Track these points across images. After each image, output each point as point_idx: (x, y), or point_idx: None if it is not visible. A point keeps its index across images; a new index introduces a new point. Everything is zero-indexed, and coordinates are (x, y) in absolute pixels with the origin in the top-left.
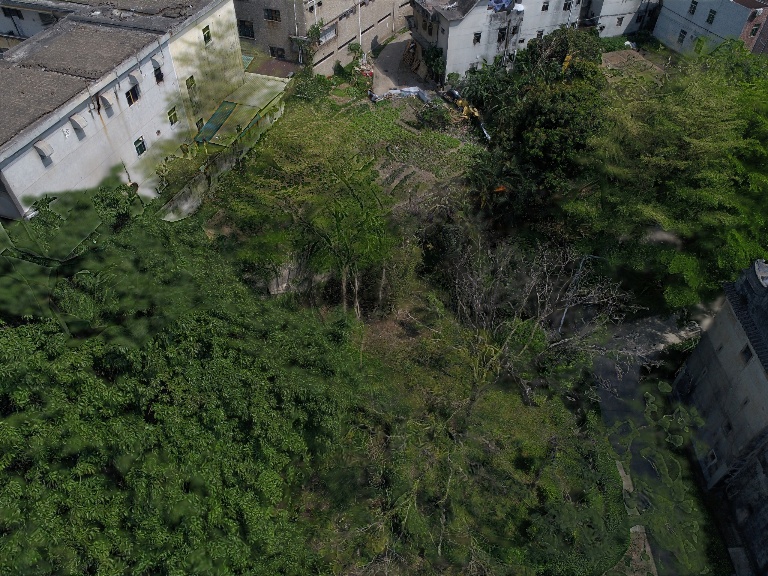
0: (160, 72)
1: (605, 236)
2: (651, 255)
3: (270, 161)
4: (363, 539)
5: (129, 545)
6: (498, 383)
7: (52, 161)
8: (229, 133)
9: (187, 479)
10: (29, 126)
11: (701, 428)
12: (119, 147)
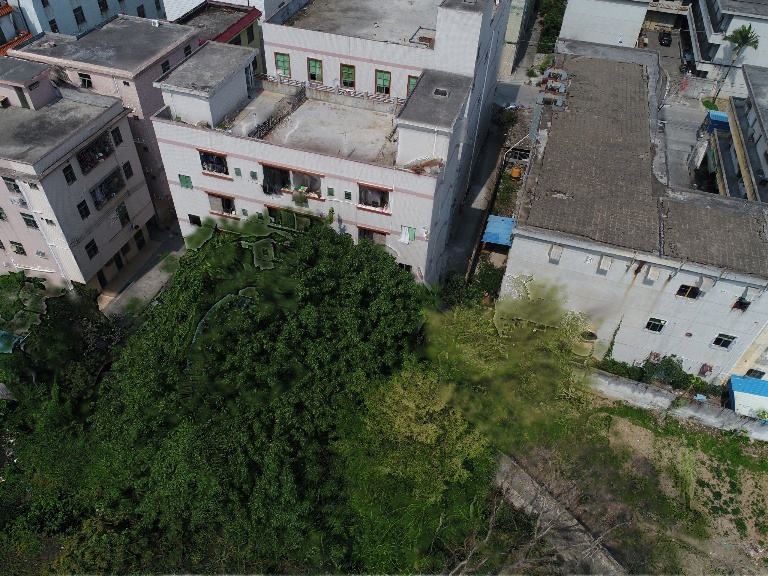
0: (749, 303)
1: None
2: None
3: (550, 421)
4: (167, 575)
5: None
6: None
7: (559, 264)
8: (761, 408)
9: (168, 411)
10: (568, 233)
11: None
12: (631, 307)
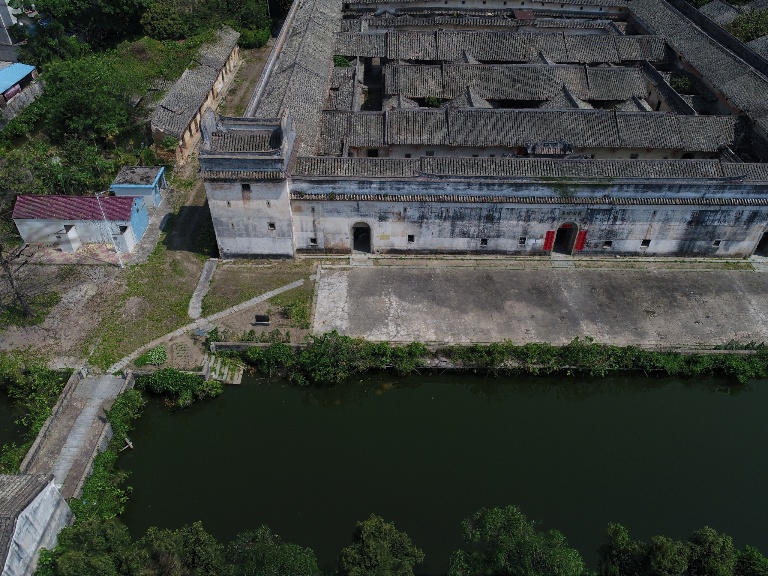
0: None
1: None
2: None
3: None
4: None
5: None
6: (242, 27)
7: None
8: None
9: None
10: None
11: None
12: None
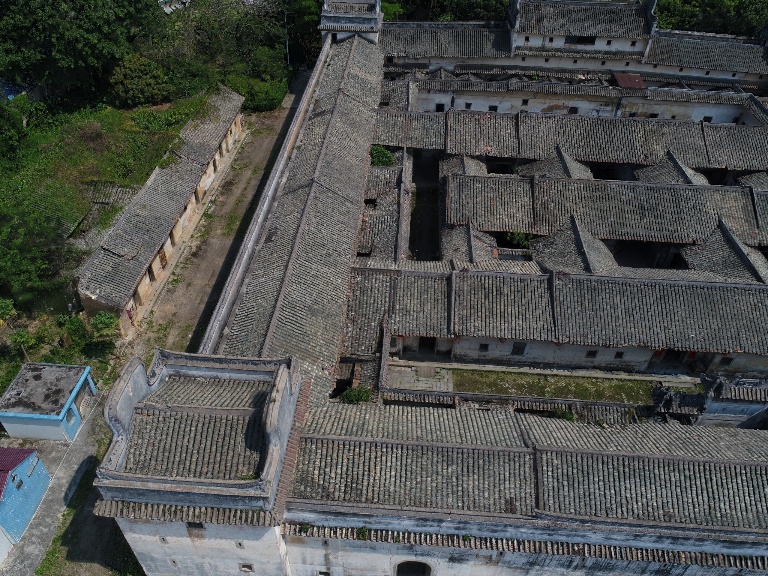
0: None
1: (291, 3)
2: (303, 5)
3: None
4: None
5: (72, 5)
6: (252, 76)
7: None
8: None
9: None
10: None
11: None
12: None
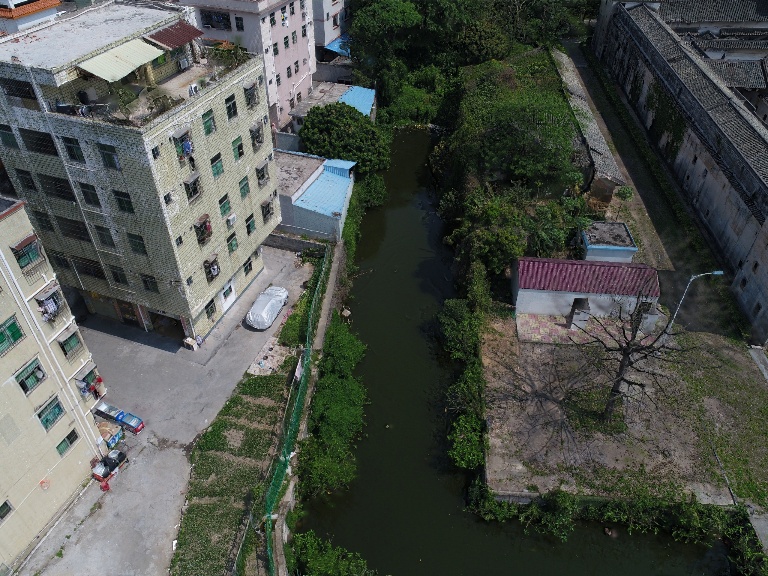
0: None
1: None
2: None
3: None
4: None
5: None
6: (524, 44)
7: None
8: None
9: None
10: None
11: (597, 44)
12: None
